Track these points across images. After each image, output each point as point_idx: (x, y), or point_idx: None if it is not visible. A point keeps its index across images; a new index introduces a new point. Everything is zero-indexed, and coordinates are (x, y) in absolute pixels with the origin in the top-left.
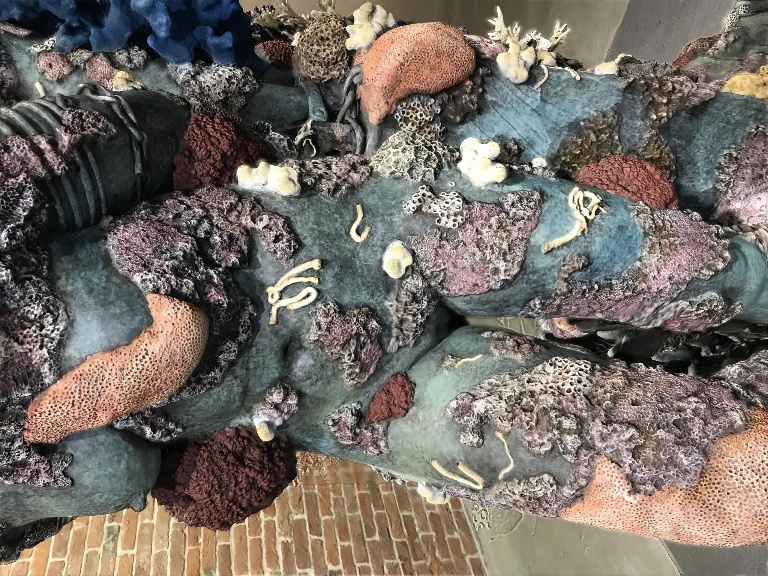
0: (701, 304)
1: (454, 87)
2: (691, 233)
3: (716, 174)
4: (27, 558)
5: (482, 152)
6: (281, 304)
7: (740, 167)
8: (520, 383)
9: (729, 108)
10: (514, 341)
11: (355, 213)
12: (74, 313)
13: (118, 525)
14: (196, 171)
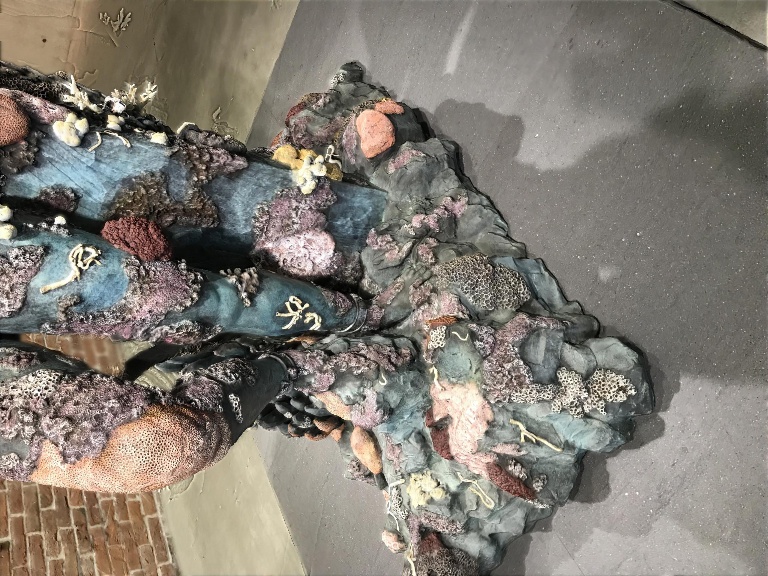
0: (180, 328)
1: (10, 145)
2: (170, 280)
3: (253, 222)
4: None
5: None
6: None
7: (272, 218)
8: (6, 389)
9: (260, 175)
10: (14, 357)
11: None
12: None
13: None
14: None
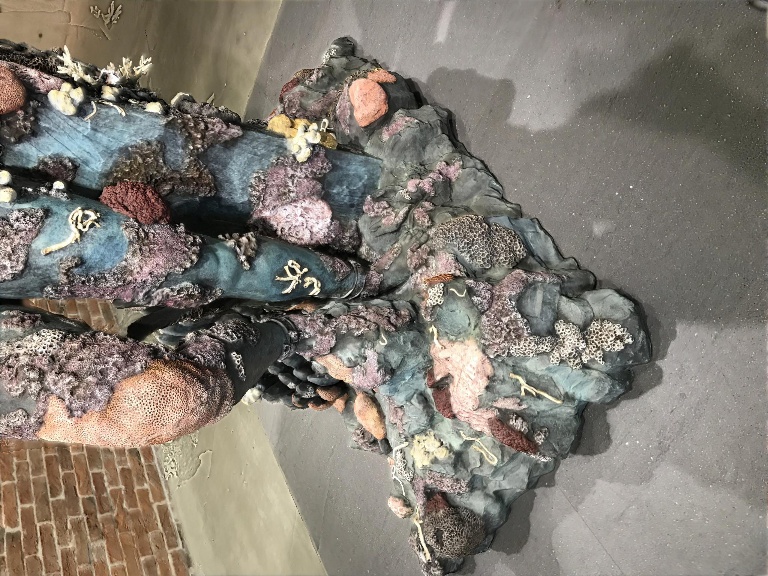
0: (181, 290)
1: (6, 114)
2: (170, 242)
3: (249, 191)
4: None
5: None
6: None
7: (268, 186)
8: (12, 348)
9: (255, 144)
10: (19, 318)
11: None
12: None
13: None
14: None
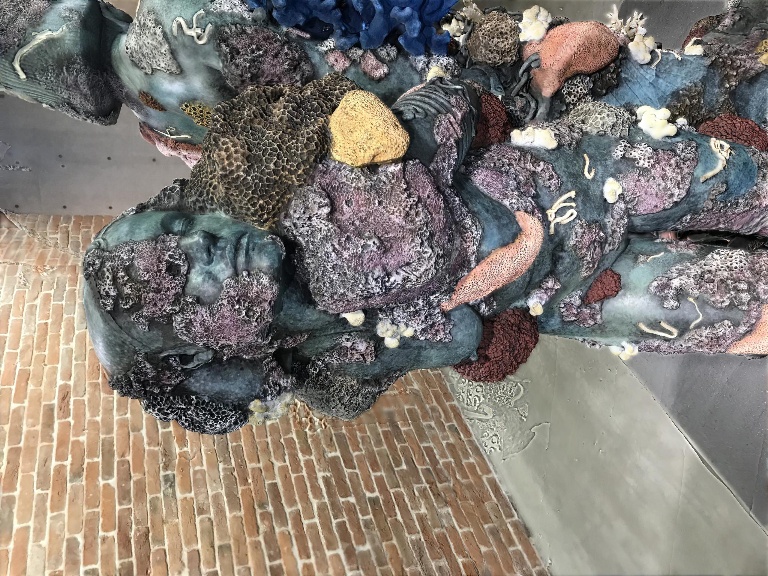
0: None
1: (603, 68)
2: None
3: (763, 127)
4: (96, 508)
5: (658, 115)
6: (556, 221)
7: None
8: (699, 267)
9: None
10: (685, 242)
11: (584, 160)
12: (483, 224)
13: (173, 473)
14: (490, 134)
